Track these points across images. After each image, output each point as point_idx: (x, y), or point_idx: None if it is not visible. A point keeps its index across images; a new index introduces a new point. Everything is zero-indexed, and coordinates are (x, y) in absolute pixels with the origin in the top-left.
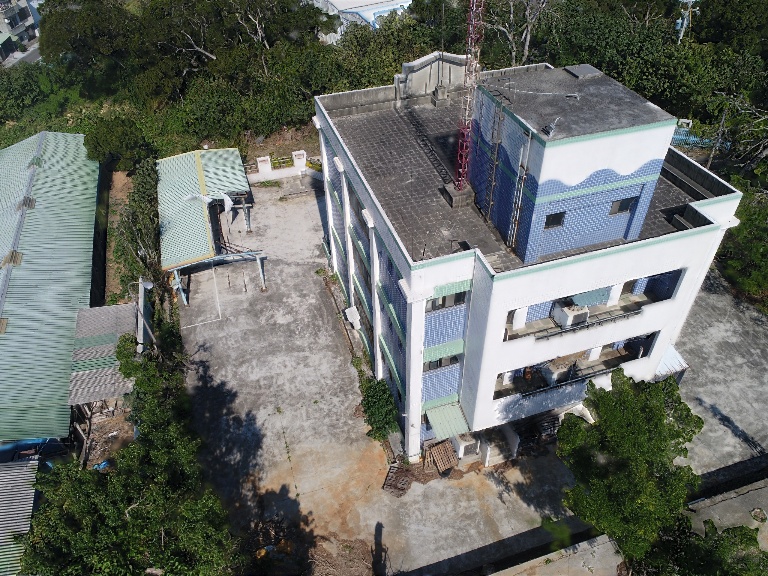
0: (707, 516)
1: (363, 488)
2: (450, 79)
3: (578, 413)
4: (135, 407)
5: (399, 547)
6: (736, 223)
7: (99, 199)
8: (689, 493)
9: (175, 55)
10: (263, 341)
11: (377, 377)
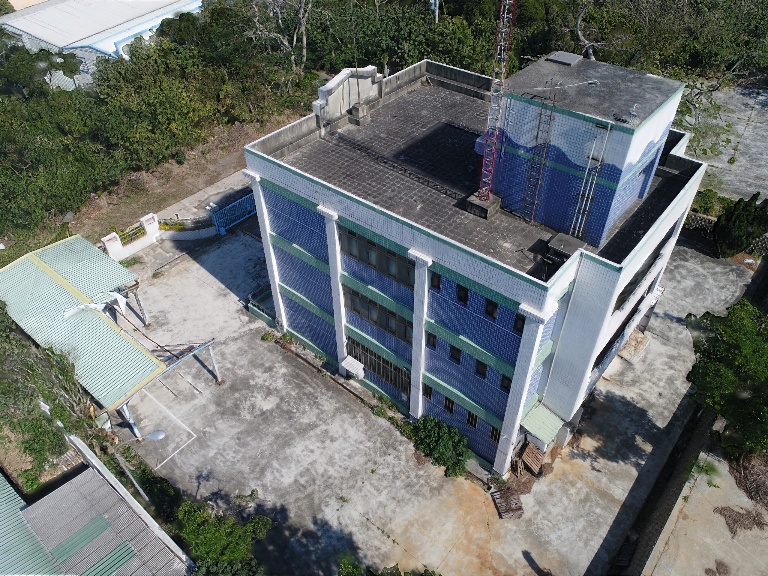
0: None
1: (484, 528)
2: (359, 94)
3: None
4: None
5: (557, 562)
6: None
7: None
8: None
9: None
10: (266, 437)
11: (416, 416)
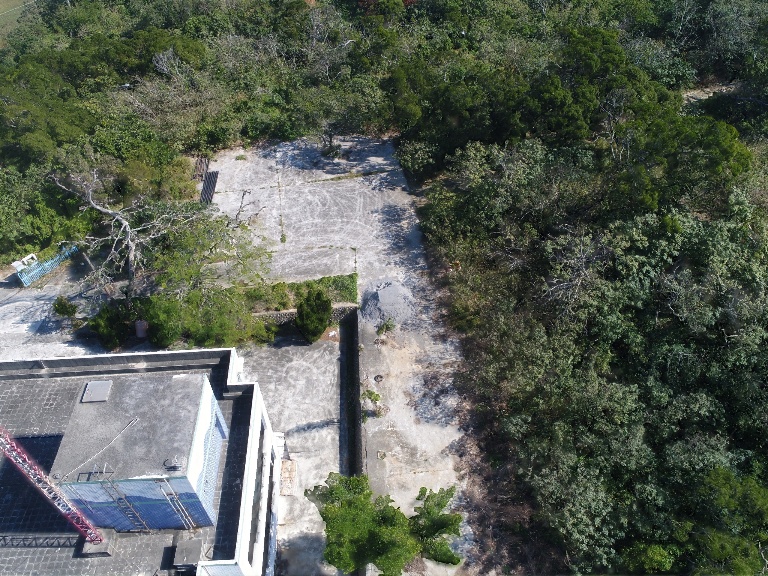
0: (373, 484)
1: None
2: None
3: None
4: None
5: None
6: None
7: None
8: None
9: None
10: None
11: None
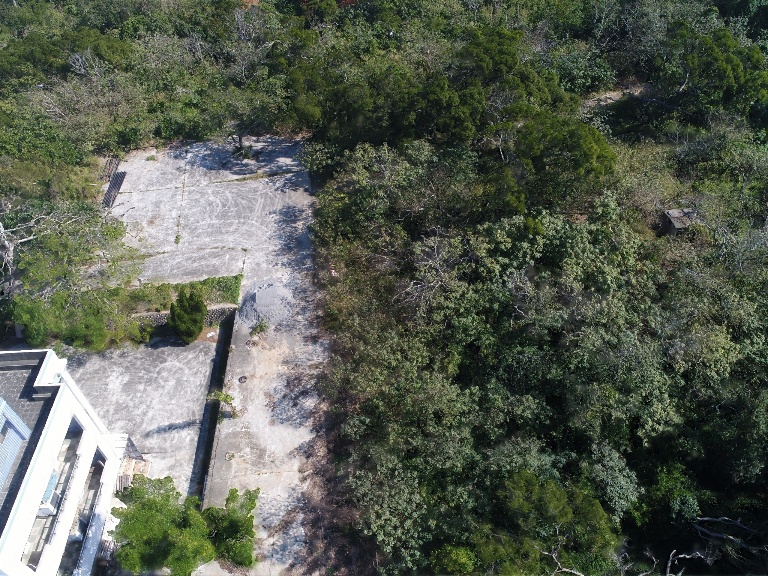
0: (216, 485)
1: None
2: None
3: (109, 523)
4: None
5: None
6: (65, 362)
7: None
8: (199, 482)
9: None
10: None
11: None
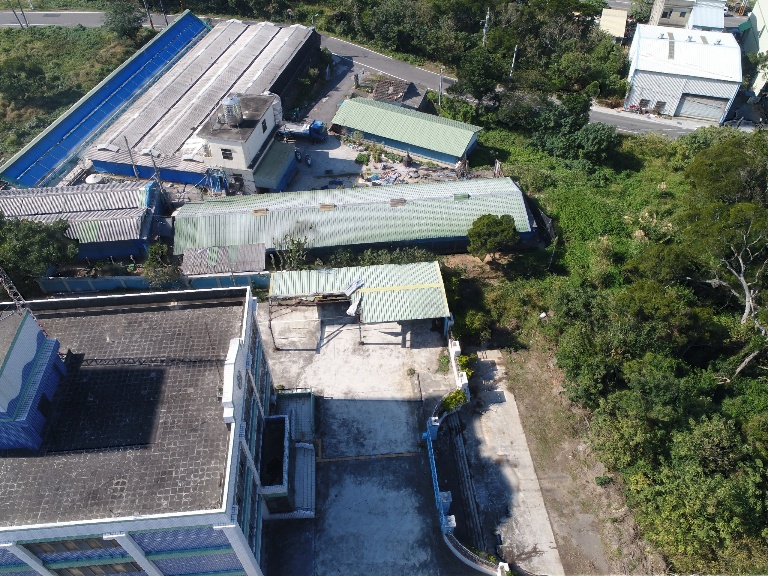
0: None
1: None
2: None
3: None
4: (159, 271)
5: None
6: None
7: (432, 244)
8: None
9: (767, 269)
10: None
11: None
